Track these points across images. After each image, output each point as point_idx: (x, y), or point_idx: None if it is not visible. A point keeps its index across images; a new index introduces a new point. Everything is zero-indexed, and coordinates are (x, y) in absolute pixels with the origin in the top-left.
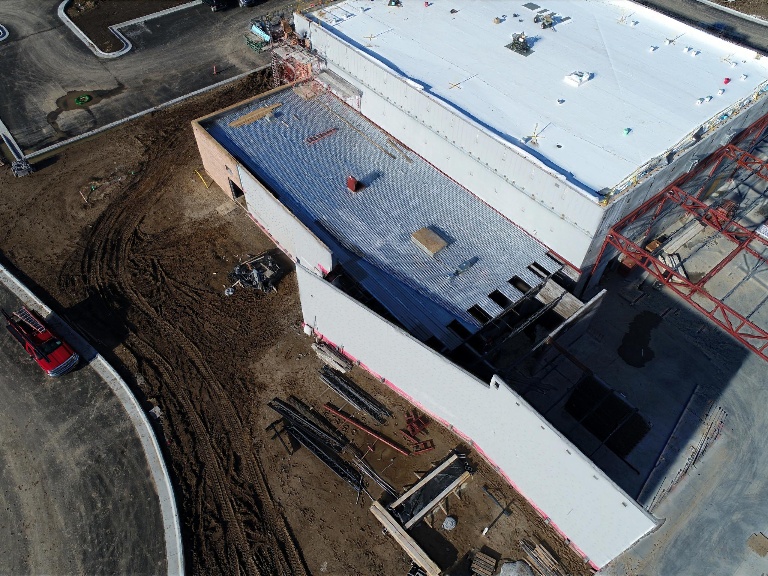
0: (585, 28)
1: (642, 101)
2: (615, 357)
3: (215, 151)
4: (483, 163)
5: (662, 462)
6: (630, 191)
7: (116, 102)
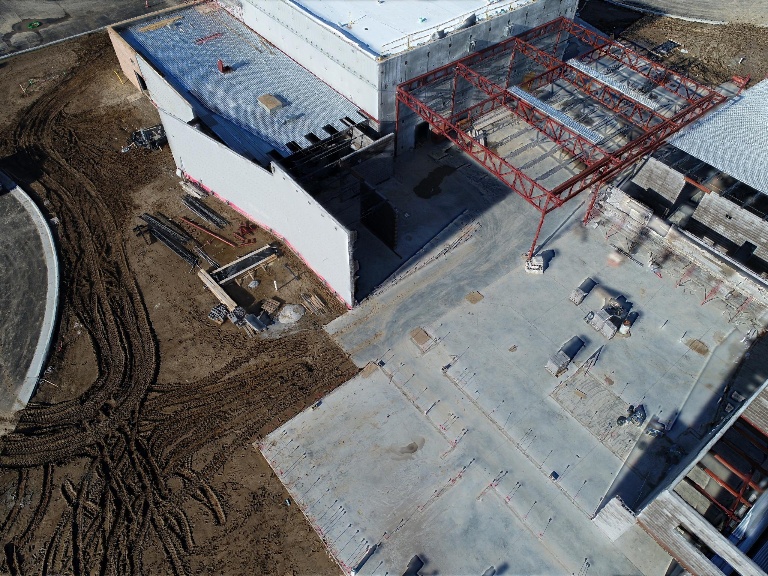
0: None
1: (444, 2)
2: (410, 192)
3: (123, 48)
4: (314, 45)
5: (421, 252)
6: (403, 53)
7: (61, 27)
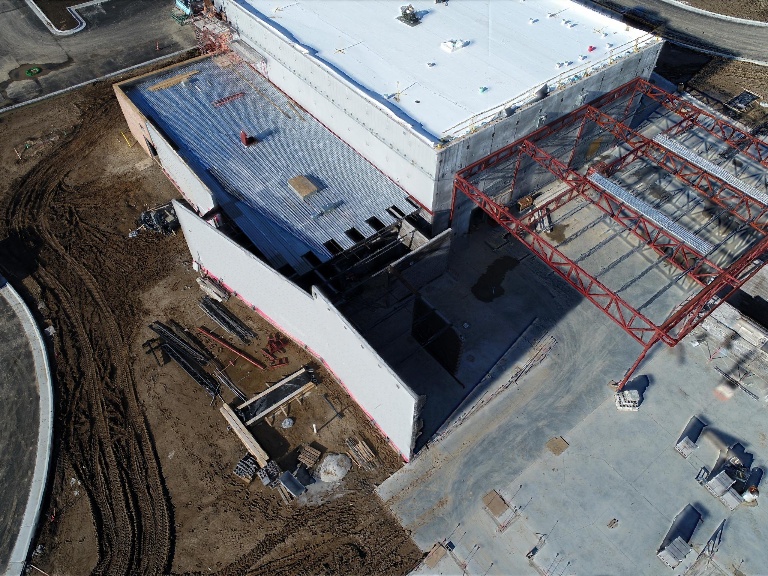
0: (476, 3)
1: (506, 65)
2: (467, 293)
3: (131, 111)
4: (355, 118)
5: (488, 379)
6: (466, 138)
7: (63, 74)
